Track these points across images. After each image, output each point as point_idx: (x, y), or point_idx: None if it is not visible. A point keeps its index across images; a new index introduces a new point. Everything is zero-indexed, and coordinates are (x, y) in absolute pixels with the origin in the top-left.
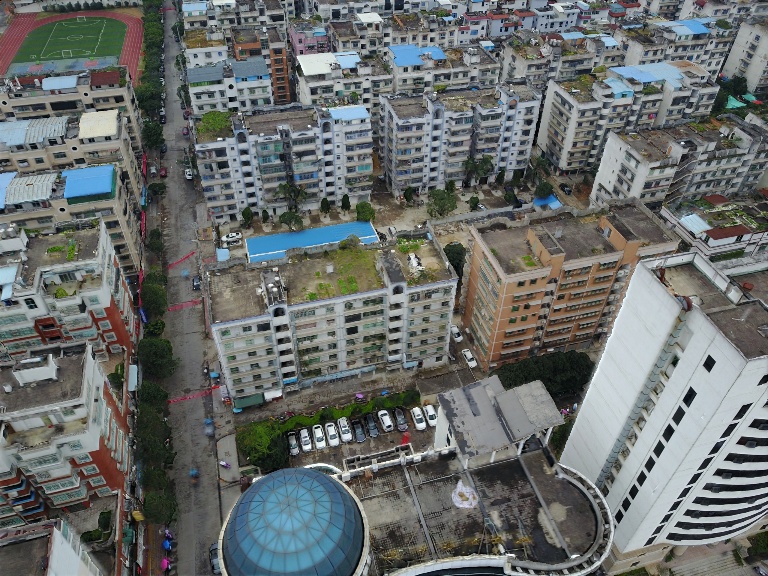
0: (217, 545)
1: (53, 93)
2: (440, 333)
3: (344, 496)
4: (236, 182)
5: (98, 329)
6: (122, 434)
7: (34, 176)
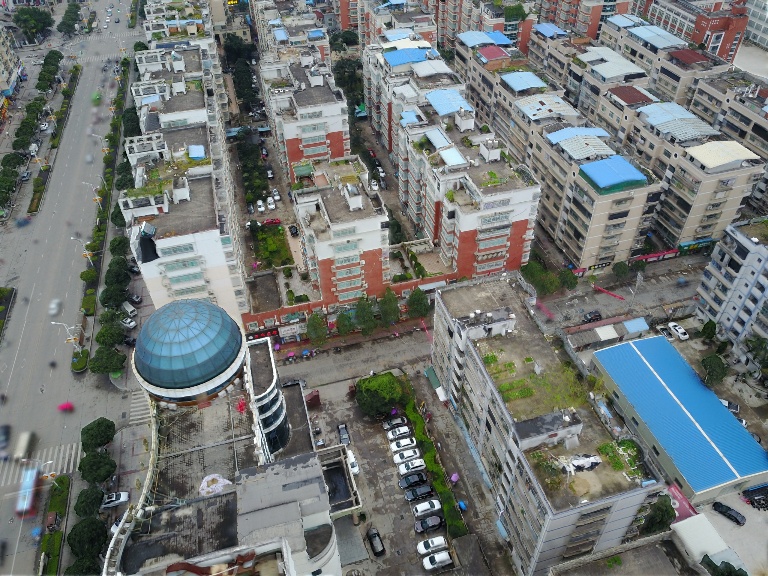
0: (303, 384)
1: (767, 117)
2: (528, 544)
3: (194, 359)
4: (738, 295)
5: (454, 241)
6: (364, 286)
7: (604, 144)
